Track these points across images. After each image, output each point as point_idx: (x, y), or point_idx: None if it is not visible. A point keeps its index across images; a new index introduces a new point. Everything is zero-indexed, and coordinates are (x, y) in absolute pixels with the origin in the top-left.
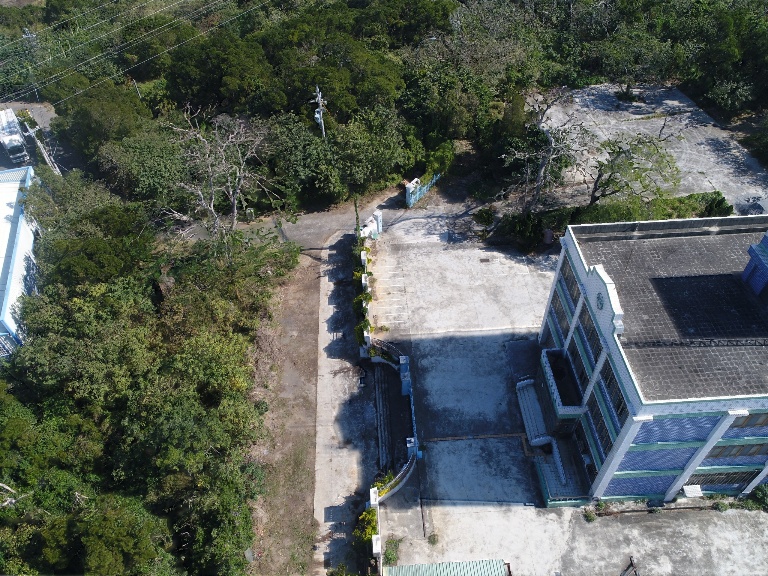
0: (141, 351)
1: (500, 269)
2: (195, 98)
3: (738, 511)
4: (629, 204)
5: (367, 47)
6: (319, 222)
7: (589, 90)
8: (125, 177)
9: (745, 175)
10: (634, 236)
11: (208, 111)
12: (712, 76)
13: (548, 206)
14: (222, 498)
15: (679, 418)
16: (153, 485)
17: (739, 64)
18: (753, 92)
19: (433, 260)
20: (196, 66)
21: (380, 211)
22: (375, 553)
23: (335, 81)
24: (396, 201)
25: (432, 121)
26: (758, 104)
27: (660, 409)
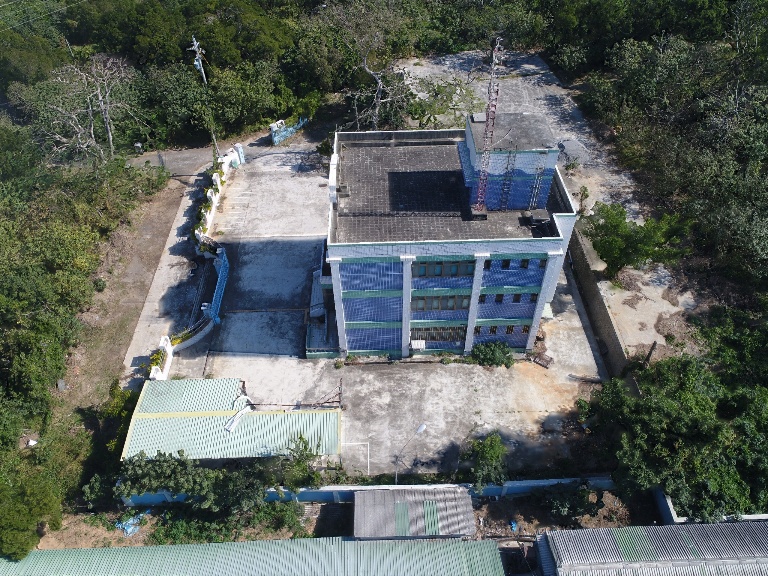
0: (3, 235)
1: None
2: None
3: (459, 364)
4: None
5: (275, 16)
6: (196, 155)
7: (461, 55)
8: (33, 114)
9: (566, 123)
10: (391, 143)
11: None
12: (563, 43)
13: None
14: None
15: (369, 264)
16: (1, 338)
17: (585, 32)
18: (589, 55)
19: (279, 184)
20: (119, 28)
21: (250, 148)
22: (151, 378)
23: (220, 36)
24: (266, 140)
25: (303, 73)
26: (599, 67)
27: (344, 251)
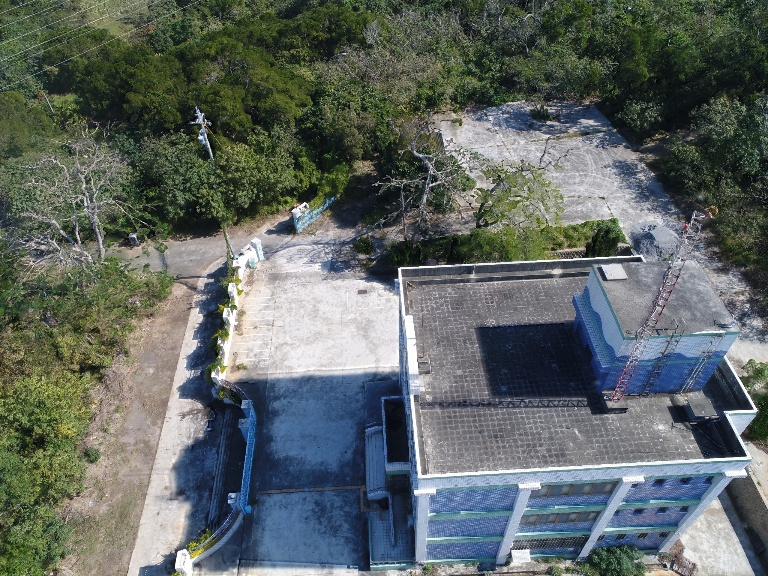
0: None
1: (376, 301)
2: (109, 113)
3: None
4: (503, 236)
5: (285, 61)
6: (203, 248)
7: (505, 108)
8: (5, 200)
9: (646, 201)
10: (471, 279)
11: (107, 129)
12: (627, 95)
13: (439, 233)
14: (12, 562)
15: None
16: None
17: (654, 83)
18: (663, 113)
19: (309, 291)
20: (105, 80)
21: (268, 236)
22: None
23: (227, 100)
24: (286, 226)
25: (327, 142)
26: (672, 124)
27: (441, 483)
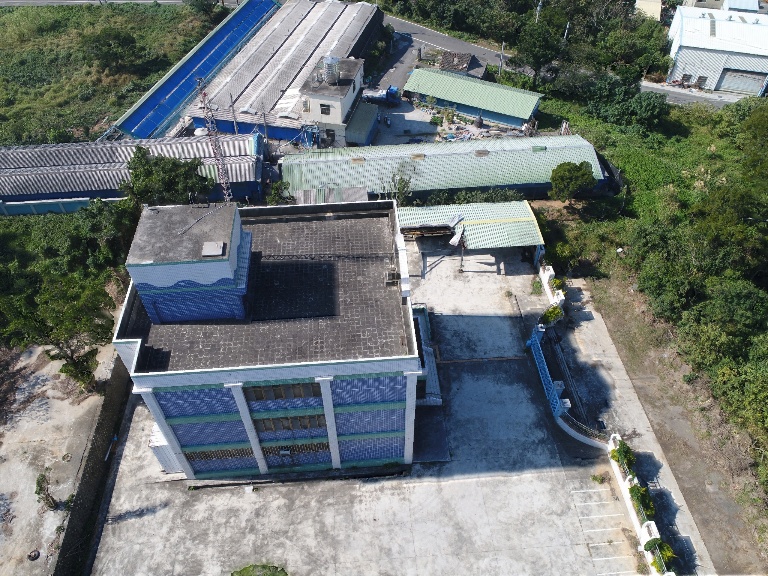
0: None
1: None
2: None
3: None
4: None
5: None
6: None
7: None
8: None
9: None
10: None
11: None
12: None
13: None
14: None
15: None
16: None
17: None
18: None
19: None
20: None
21: None
22: None
23: None
24: None
25: None
26: None
27: None
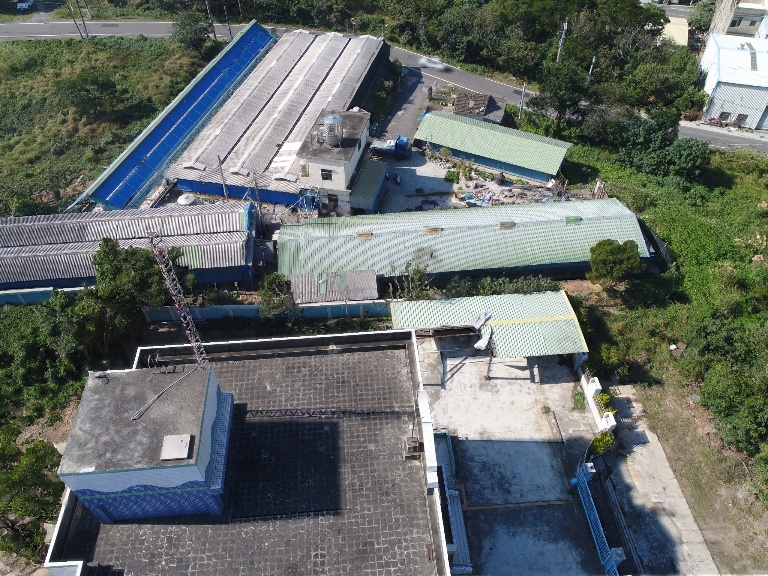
0: None
1: None
2: None
3: None
4: None
5: None
6: None
7: None
8: None
9: None
10: None
11: None
12: None
13: None
14: None
15: None
16: None
17: None
18: None
19: None
20: None
21: None
22: None
23: None
24: None
25: None
26: None
27: None
